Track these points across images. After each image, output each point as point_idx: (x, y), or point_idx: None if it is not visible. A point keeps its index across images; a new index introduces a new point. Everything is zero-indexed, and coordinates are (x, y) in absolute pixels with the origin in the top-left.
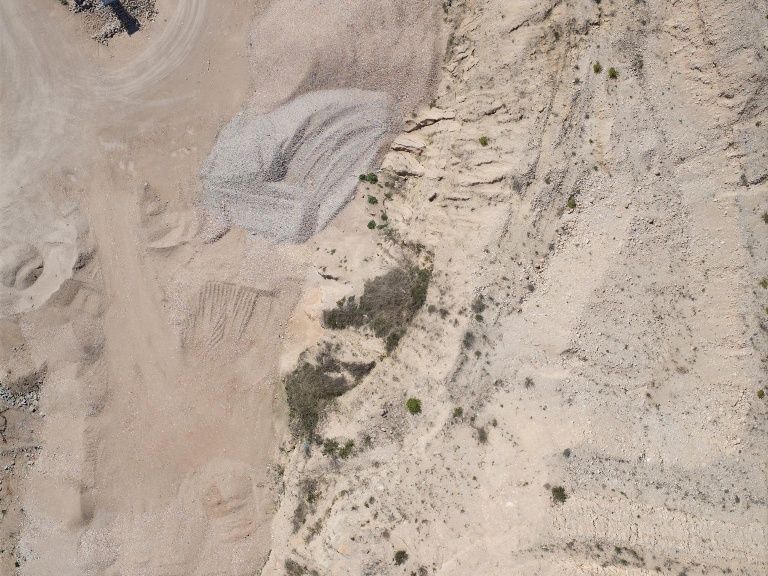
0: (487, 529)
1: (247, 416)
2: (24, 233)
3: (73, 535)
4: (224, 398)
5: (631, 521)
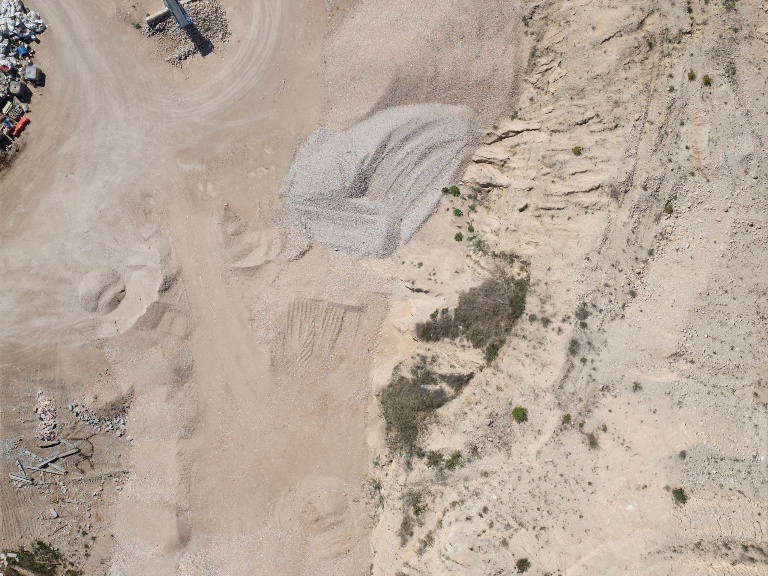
0: (609, 533)
1: (339, 432)
2: (105, 257)
3: (170, 559)
4: (316, 415)
5: (753, 519)
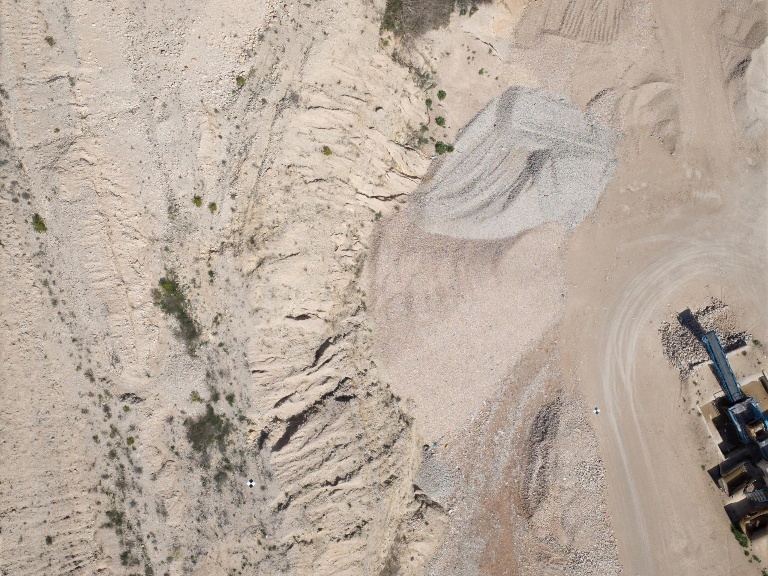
0: None
1: None
2: None
3: None
4: None
5: None
